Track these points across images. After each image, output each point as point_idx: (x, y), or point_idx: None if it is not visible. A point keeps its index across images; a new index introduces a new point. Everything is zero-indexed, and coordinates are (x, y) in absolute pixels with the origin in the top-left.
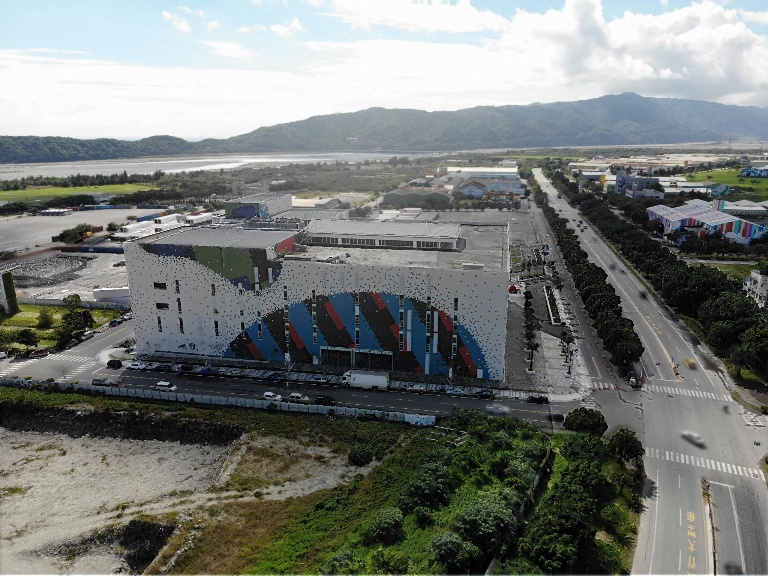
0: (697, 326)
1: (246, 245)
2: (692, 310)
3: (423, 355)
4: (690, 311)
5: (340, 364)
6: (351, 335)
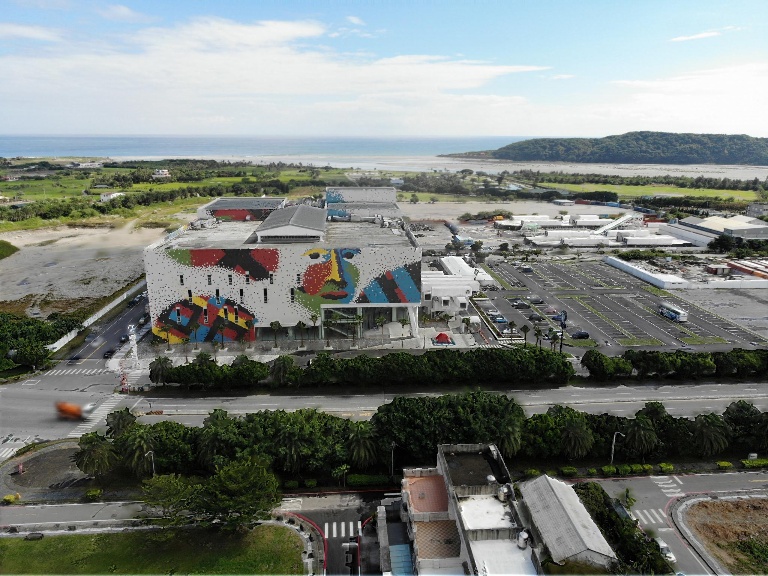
0: None
1: None
2: None
3: None
4: None
5: None
6: None
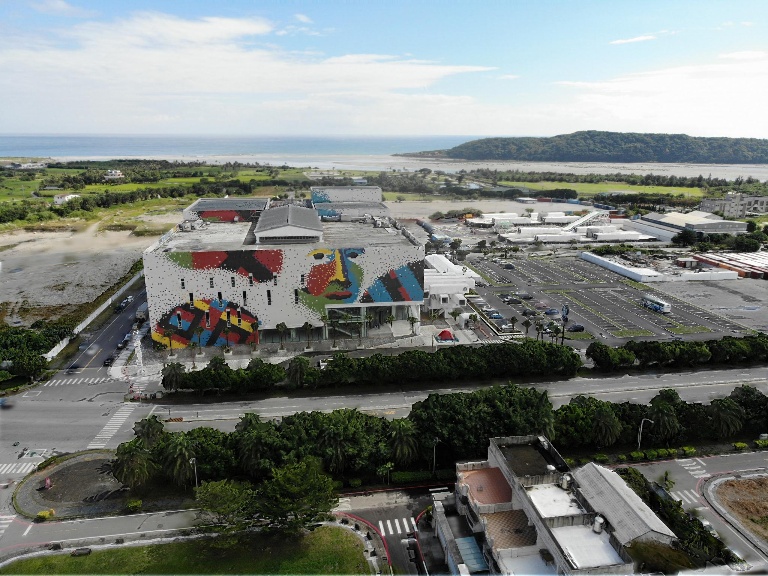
0: None
1: (200, 209)
2: None
3: None
4: None
5: None
6: None
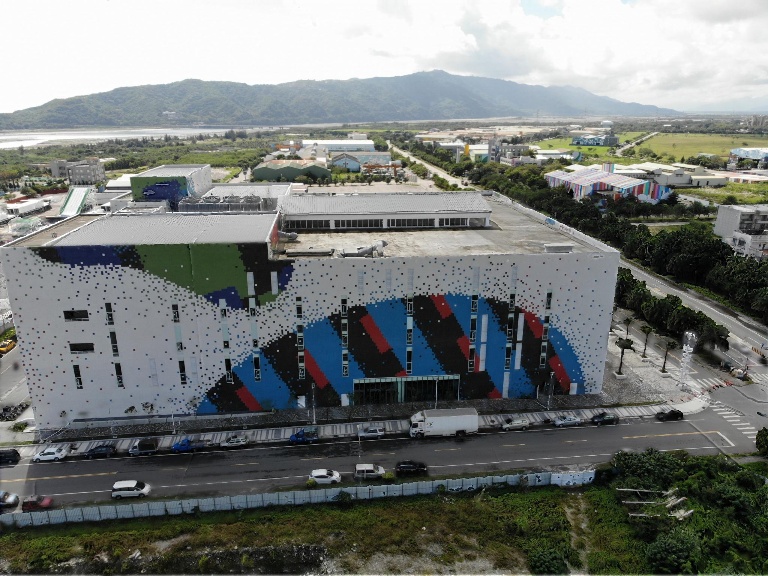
0: (713, 295)
1: (223, 238)
2: (693, 277)
3: (500, 374)
4: (691, 279)
5: (383, 401)
6: (400, 358)
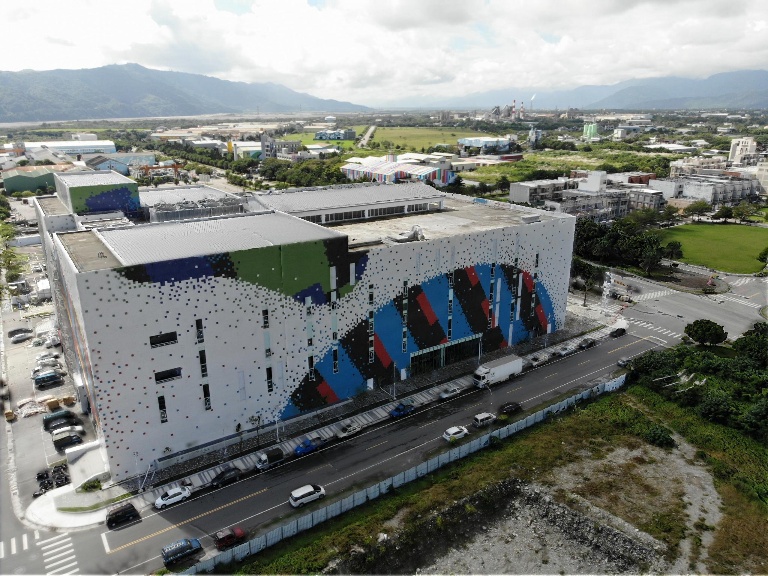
0: None
1: (294, 238)
2: None
3: (508, 326)
4: None
5: (431, 368)
6: (444, 327)
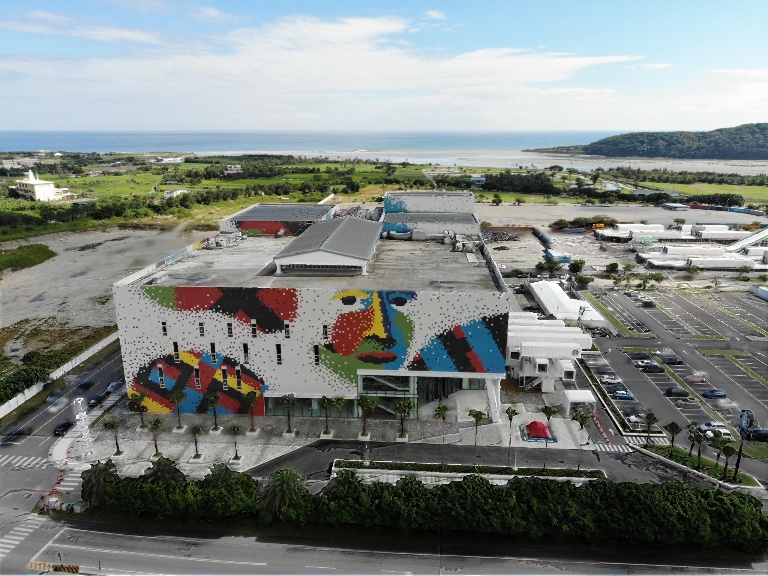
0: None
1: (243, 218)
2: None
3: None
4: None
5: None
6: None
